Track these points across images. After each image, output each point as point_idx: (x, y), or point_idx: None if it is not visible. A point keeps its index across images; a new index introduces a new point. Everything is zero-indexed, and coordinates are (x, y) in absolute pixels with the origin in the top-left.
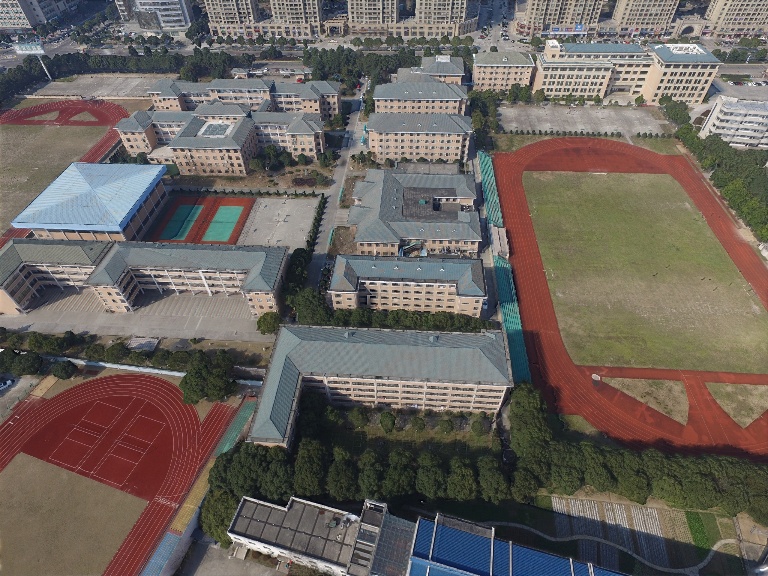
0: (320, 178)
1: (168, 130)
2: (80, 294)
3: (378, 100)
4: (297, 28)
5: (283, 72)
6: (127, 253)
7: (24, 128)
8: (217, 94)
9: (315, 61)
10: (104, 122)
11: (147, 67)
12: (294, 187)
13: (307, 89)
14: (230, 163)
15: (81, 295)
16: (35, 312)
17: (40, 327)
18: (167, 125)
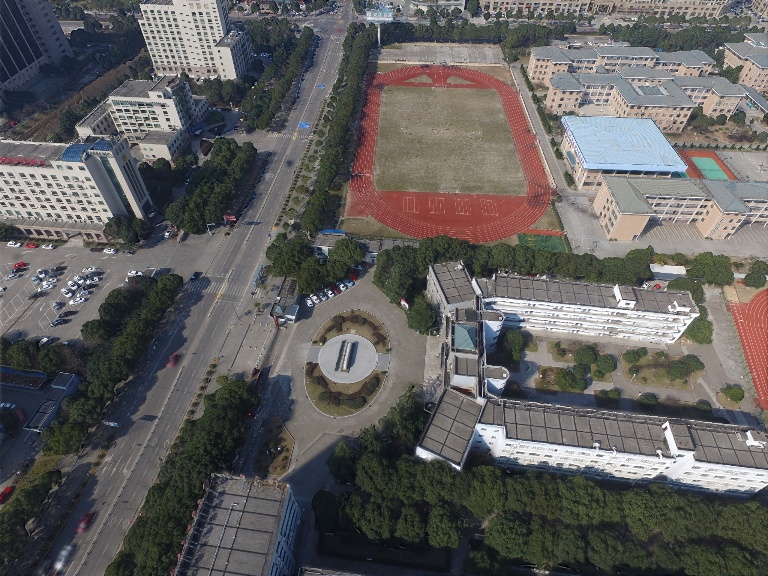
0: (765, 134)
1: (591, 91)
2: (662, 225)
3: (763, 69)
4: (568, 5)
5: (602, 45)
6: (734, 187)
7: (414, 89)
8: (605, 61)
9: (635, 35)
10: (484, 85)
11: (471, 37)
12: (736, 142)
13: (690, 58)
14: (674, 120)
15: (664, 226)
16: (642, 239)
17: (663, 250)
18: (592, 86)
